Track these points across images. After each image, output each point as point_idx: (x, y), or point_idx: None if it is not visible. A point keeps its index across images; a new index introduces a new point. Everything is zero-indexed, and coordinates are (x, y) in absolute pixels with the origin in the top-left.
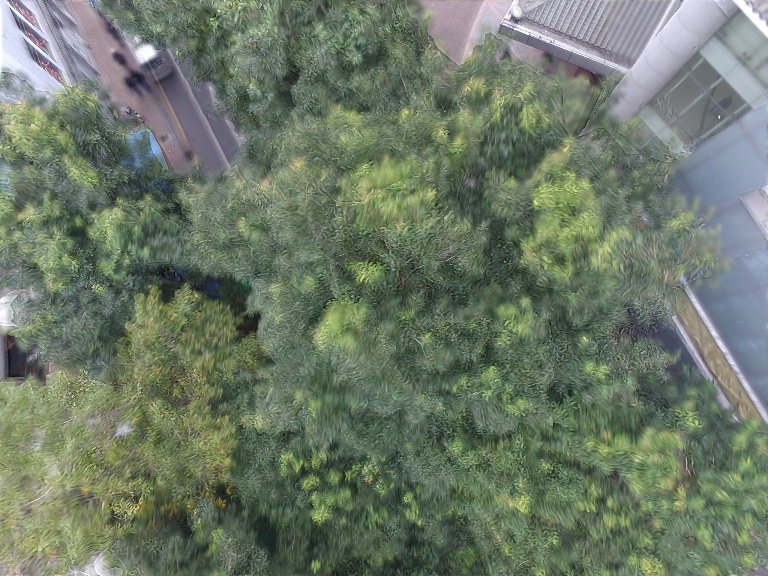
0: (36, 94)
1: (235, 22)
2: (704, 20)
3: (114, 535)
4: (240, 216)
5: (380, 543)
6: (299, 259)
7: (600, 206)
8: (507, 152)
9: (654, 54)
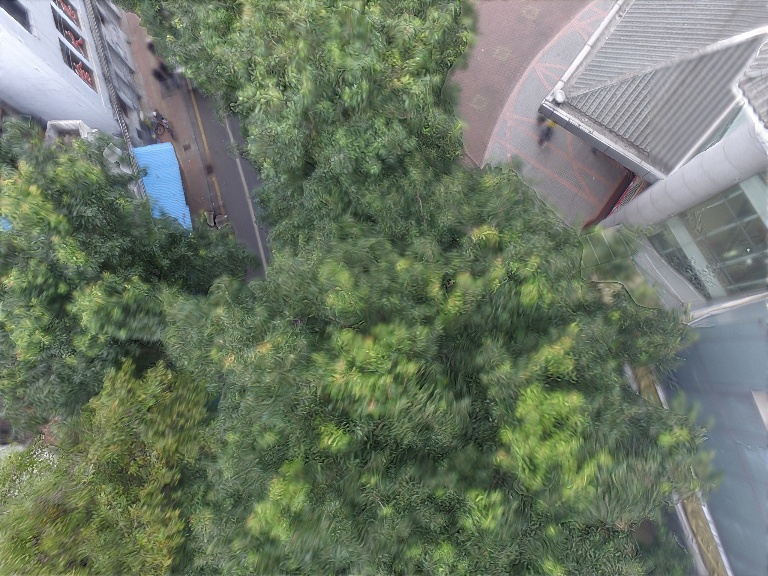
0: (42, 144)
1: (256, 112)
2: (749, 160)
3: None
4: (218, 339)
5: None
6: None
7: (598, 403)
8: (510, 321)
9: (692, 175)
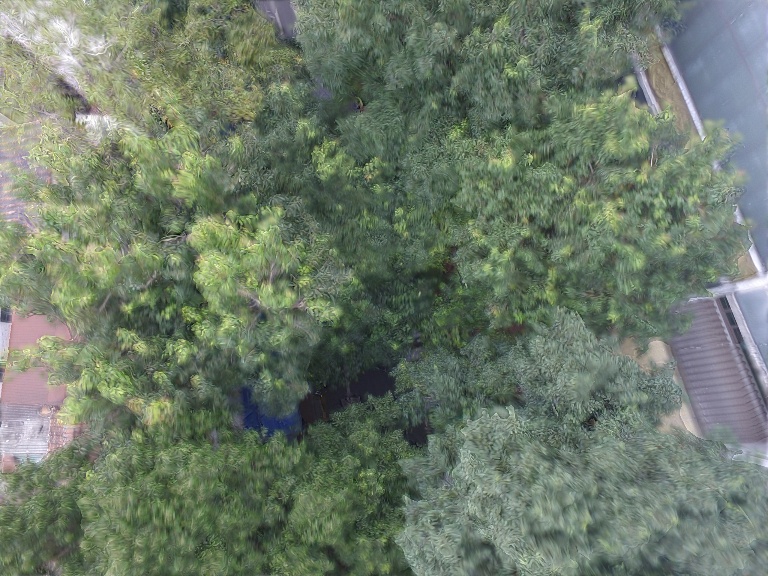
0: None
1: None
2: None
3: (148, 132)
4: None
5: (367, 241)
6: None
7: None
8: None
9: None
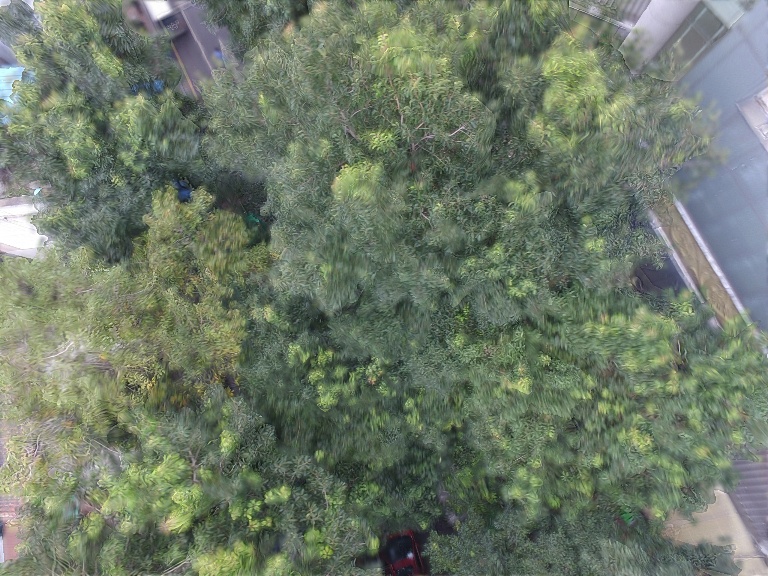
0: None
1: None
2: None
3: None
4: (259, 93)
5: (381, 444)
6: (314, 130)
7: (602, 88)
8: (515, 39)
9: (658, 5)
